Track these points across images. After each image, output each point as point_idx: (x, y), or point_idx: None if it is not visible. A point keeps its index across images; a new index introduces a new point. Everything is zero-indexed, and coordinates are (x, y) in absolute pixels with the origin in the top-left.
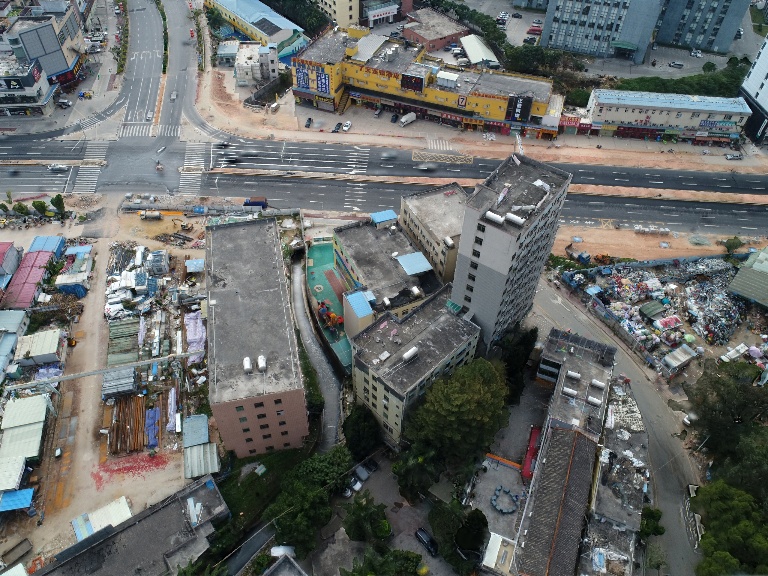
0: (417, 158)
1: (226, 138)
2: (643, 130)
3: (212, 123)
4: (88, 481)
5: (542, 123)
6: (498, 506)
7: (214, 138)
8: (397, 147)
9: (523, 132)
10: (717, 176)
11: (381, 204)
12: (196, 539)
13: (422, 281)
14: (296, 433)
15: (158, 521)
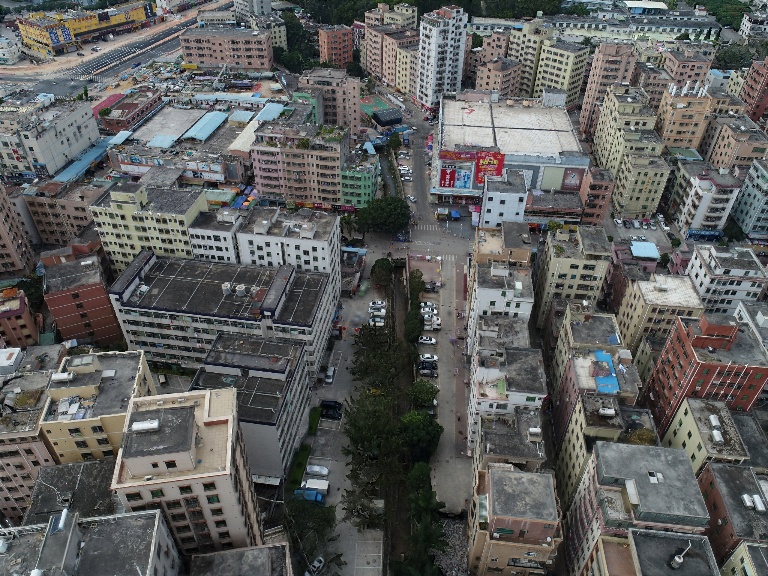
0: (144, 40)
1: (66, 70)
2: (185, 5)
3: (44, 72)
4: None
5: (157, 15)
6: (316, 45)
7: (62, 72)
8: (130, 42)
9: (155, 22)
10: (222, 6)
11: (167, 49)
12: (294, 74)
13: (238, 25)
14: (272, 58)
15: None
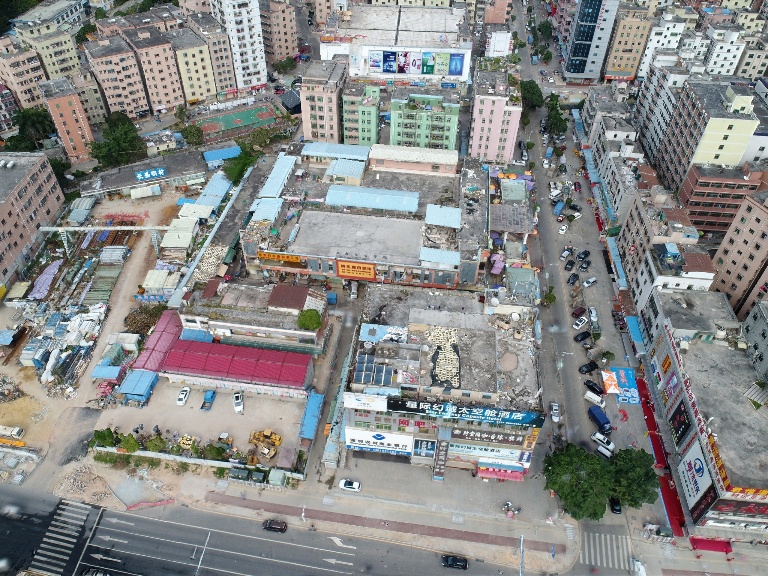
0: None
1: None
2: None
3: None
4: (152, 215)
5: None
6: None
7: None
8: None
9: None
10: None
11: None
12: None
13: None
14: None
15: (117, 183)
